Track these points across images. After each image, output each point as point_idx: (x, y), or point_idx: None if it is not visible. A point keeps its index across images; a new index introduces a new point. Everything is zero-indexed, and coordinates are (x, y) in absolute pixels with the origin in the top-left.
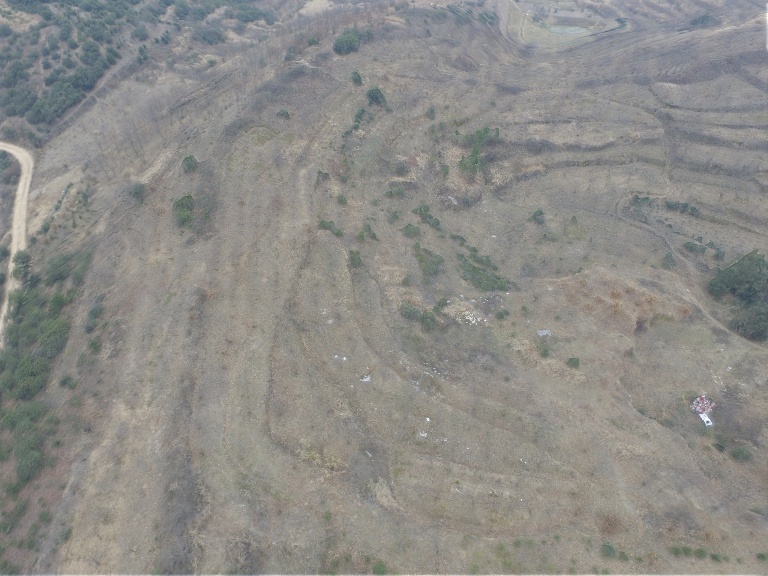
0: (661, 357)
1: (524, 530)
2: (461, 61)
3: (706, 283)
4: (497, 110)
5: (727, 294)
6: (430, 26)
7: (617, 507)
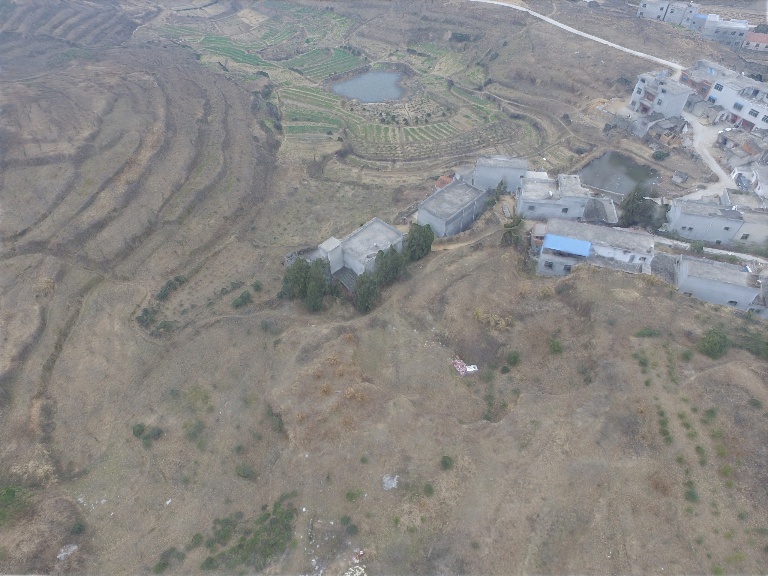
0: (409, 377)
1: (696, 575)
2: None
3: (302, 308)
4: None
5: None
6: None
7: (635, 474)
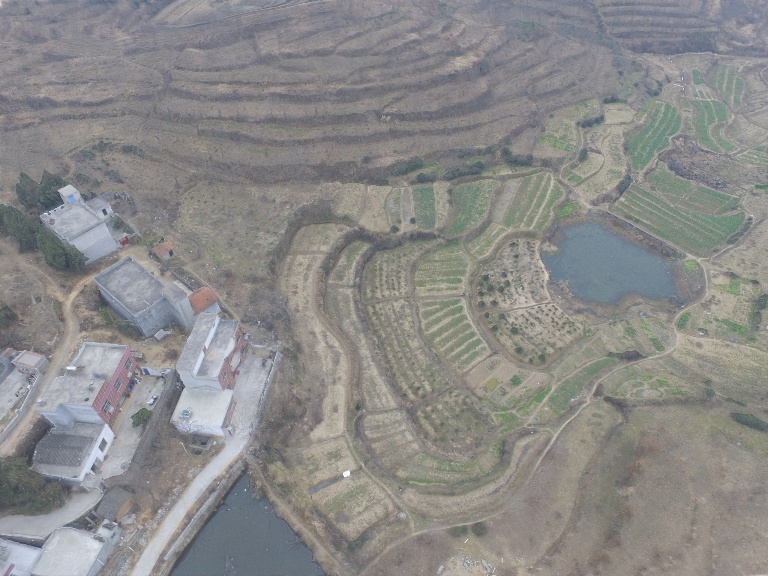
0: None
1: None
2: (25, 34)
3: None
4: (28, 74)
5: (32, 207)
6: (39, 5)
7: None
